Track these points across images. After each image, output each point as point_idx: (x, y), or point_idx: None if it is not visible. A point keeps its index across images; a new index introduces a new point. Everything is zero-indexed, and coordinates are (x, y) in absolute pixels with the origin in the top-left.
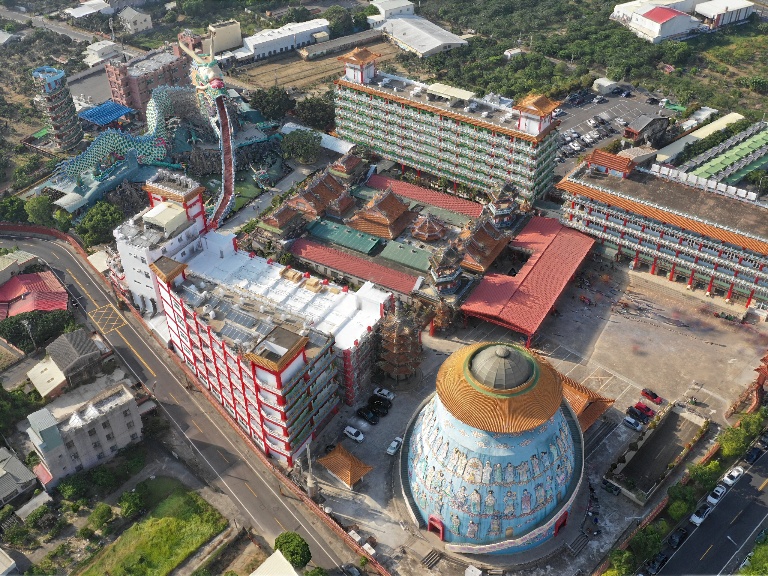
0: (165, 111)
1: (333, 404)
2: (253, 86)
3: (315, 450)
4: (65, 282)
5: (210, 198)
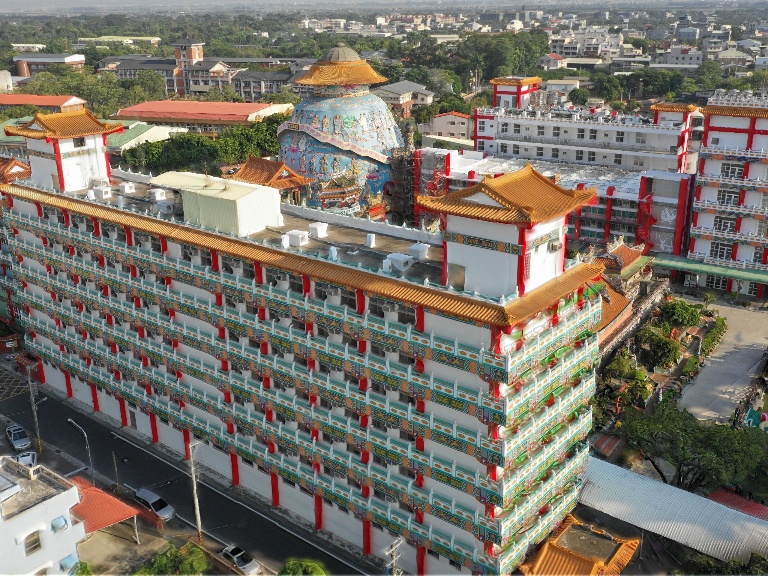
0: None
1: None
2: None
3: None
4: None
5: None
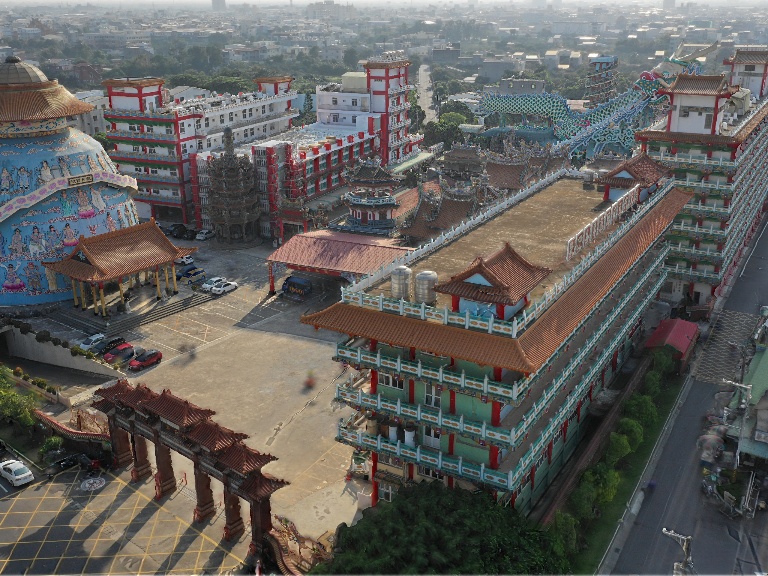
0: (640, 114)
1: (173, 199)
2: None
3: (141, 221)
4: None
5: None
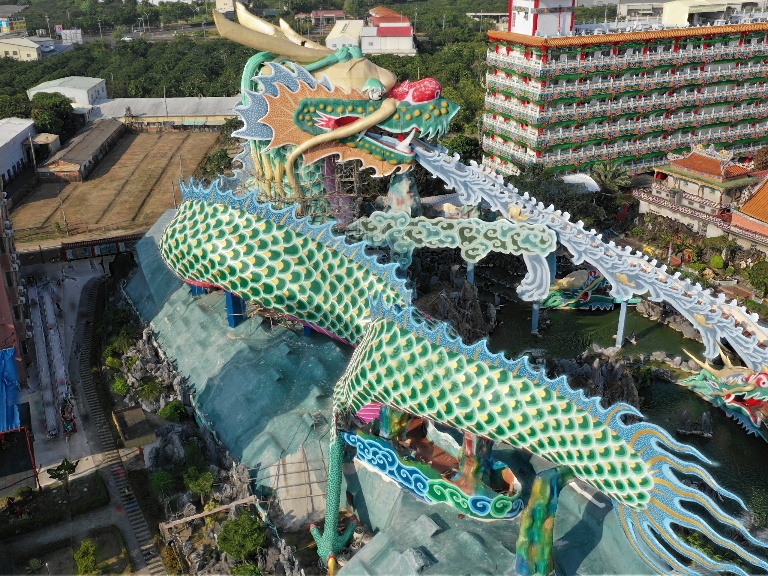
0: None
1: None
2: (92, 234)
3: None
4: None
5: (689, 354)
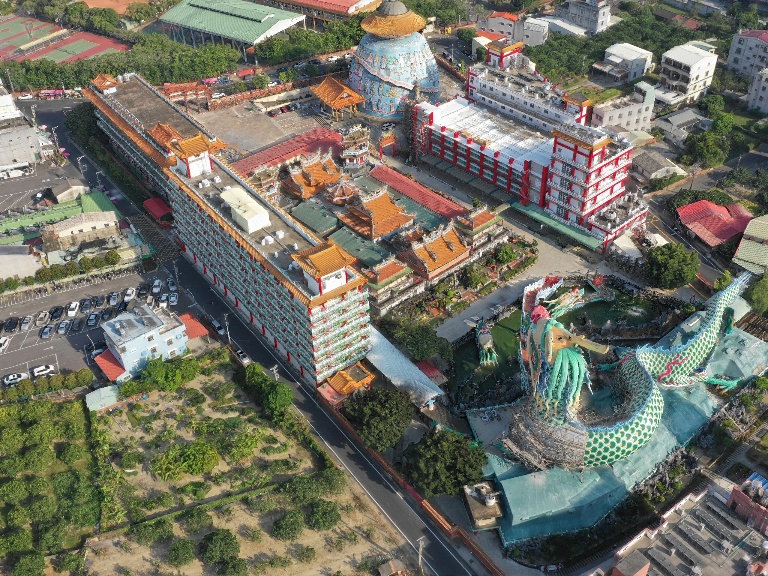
0: None
1: None
2: None
3: None
4: (696, 251)
5: None
